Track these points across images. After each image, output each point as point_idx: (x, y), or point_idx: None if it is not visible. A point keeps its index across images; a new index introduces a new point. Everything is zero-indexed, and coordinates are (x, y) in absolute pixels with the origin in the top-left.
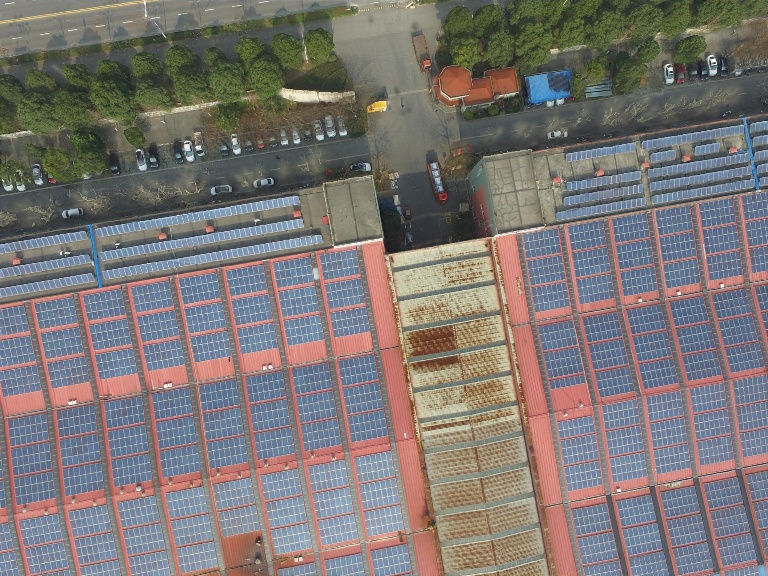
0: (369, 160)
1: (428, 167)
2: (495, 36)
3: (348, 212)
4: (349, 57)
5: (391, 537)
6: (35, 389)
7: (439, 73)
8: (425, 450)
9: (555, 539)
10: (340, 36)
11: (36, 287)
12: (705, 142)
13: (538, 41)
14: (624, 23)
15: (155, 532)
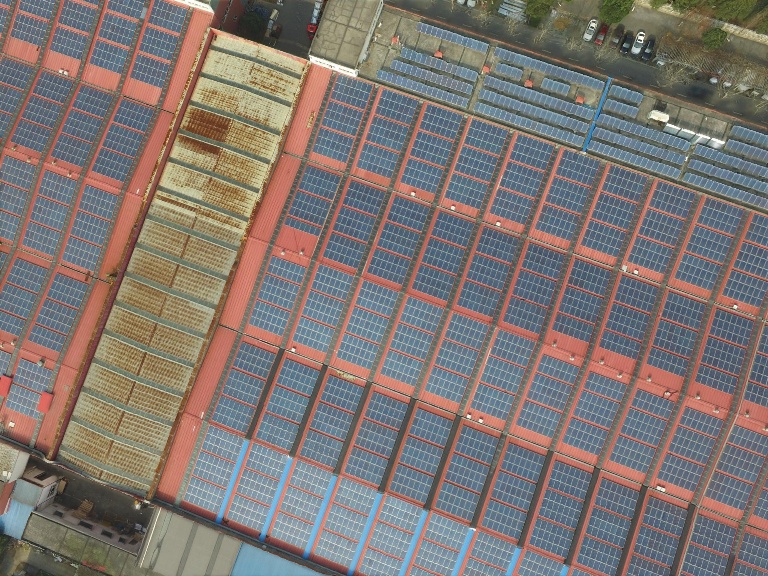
0: None
1: None
2: None
3: None
4: None
5: (80, 272)
6: None
7: None
8: (149, 215)
9: (213, 357)
10: None
11: None
12: (559, 81)
13: None
14: None
15: None
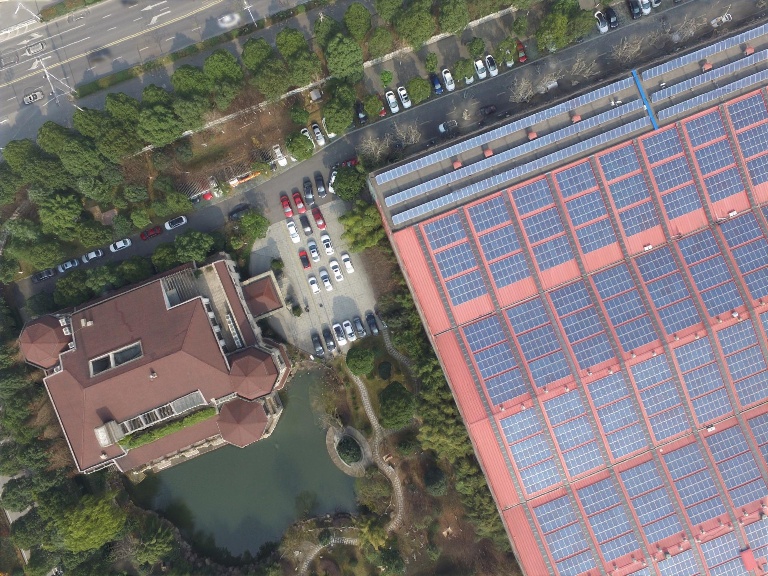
0: None
1: None
2: None
3: None
4: None
5: None
6: (611, 241)
7: None
8: None
9: None
10: None
11: (598, 140)
12: None
13: None
14: None
15: (755, 354)
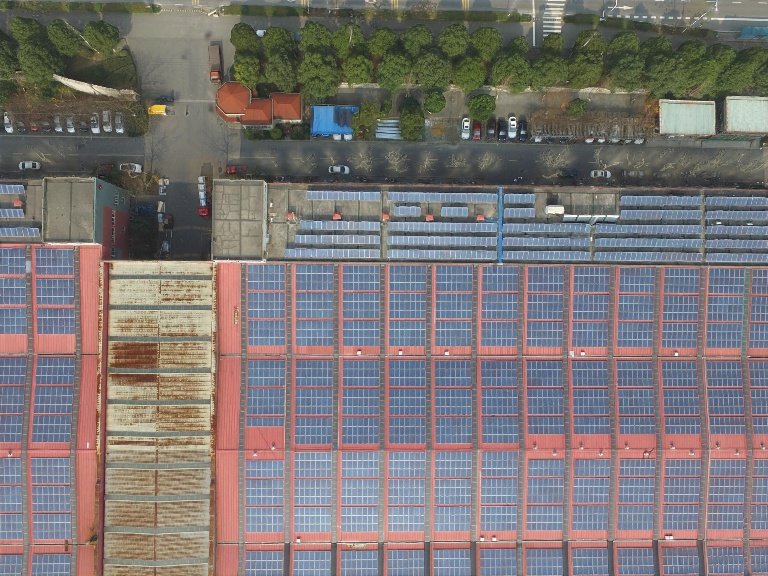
0: (142, 162)
1: None
2: (271, 59)
3: (65, 211)
4: (143, 55)
5: (57, 544)
6: None
7: None
8: (107, 463)
9: None
10: (137, 32)
11: None
12: (455, 204)
13: (316, 72)
14: (408, 69)
15: None
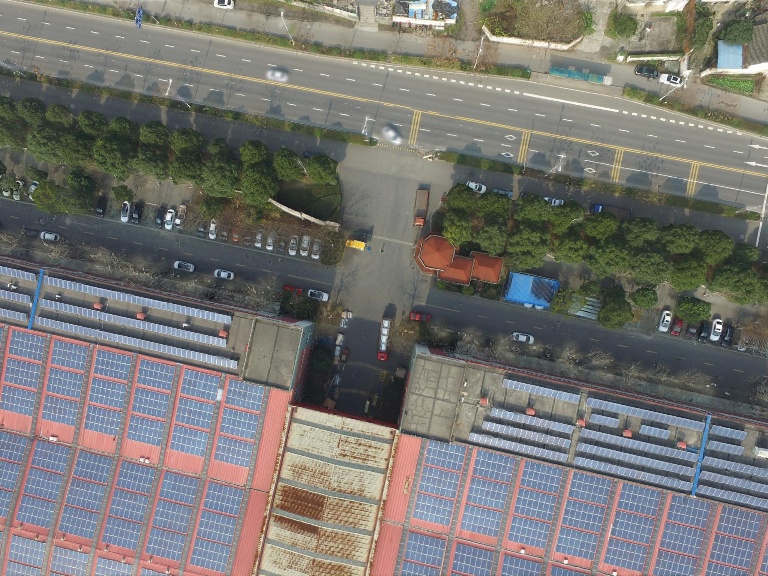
0: (330, 290)
1: (381, 320)
2: (488, 228)
3: (268, 353)
4: (350, 185)
5: None
6: None
7: (426, 237)
8: None
9: None
10: (350, 162)
11: None
12: (656, 423)
13: (530, 248)
14: (627, 263)
15: None
